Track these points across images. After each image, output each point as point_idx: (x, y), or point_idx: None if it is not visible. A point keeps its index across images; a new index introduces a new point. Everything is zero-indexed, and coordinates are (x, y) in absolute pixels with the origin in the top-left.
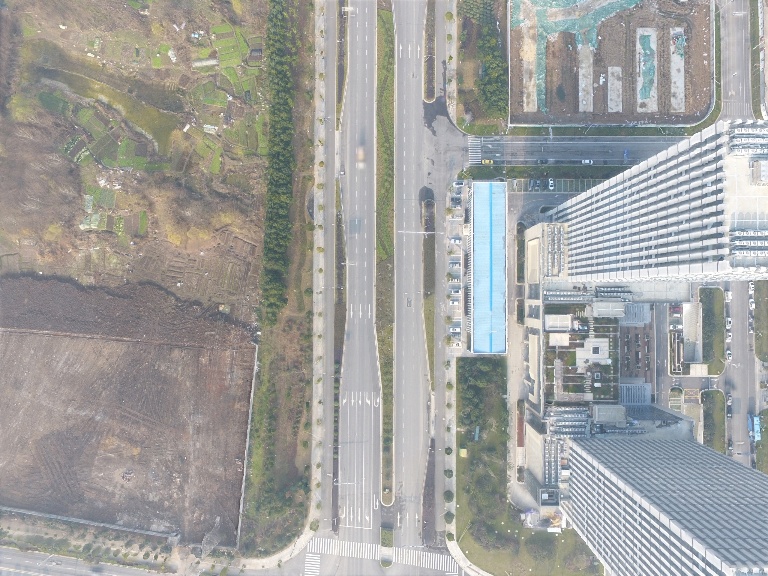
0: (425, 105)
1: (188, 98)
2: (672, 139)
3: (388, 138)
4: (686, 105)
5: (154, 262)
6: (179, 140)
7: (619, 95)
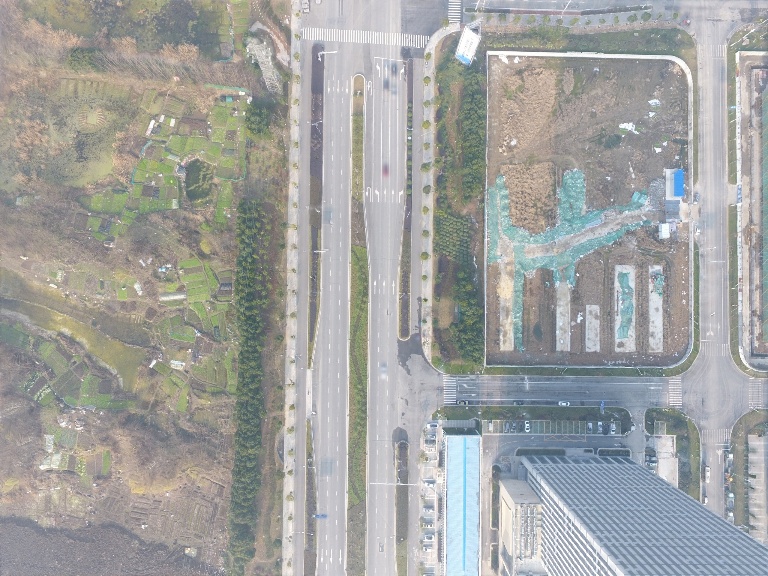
0: (399, 343)
1: (155, 332)
2: (650, 380)
3: (361, 378)
4: (664, 345)
5: (117, 503)
6: (145, 376)
7: (597, 334)
